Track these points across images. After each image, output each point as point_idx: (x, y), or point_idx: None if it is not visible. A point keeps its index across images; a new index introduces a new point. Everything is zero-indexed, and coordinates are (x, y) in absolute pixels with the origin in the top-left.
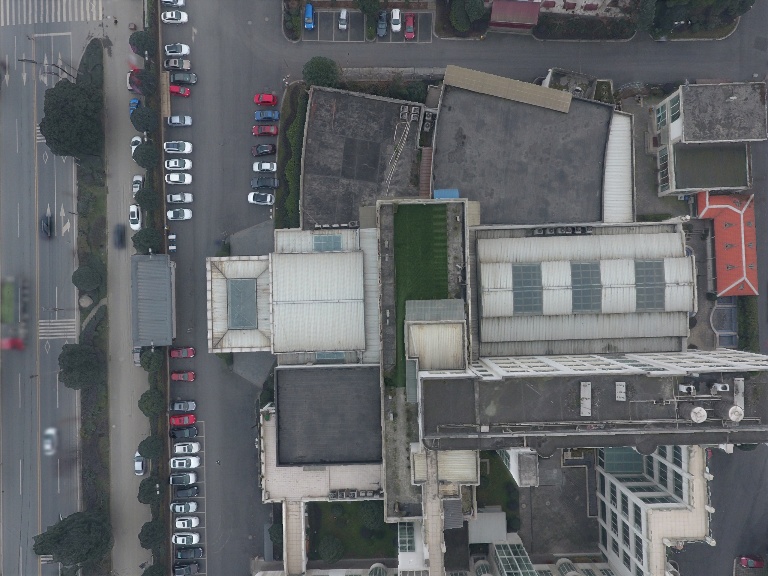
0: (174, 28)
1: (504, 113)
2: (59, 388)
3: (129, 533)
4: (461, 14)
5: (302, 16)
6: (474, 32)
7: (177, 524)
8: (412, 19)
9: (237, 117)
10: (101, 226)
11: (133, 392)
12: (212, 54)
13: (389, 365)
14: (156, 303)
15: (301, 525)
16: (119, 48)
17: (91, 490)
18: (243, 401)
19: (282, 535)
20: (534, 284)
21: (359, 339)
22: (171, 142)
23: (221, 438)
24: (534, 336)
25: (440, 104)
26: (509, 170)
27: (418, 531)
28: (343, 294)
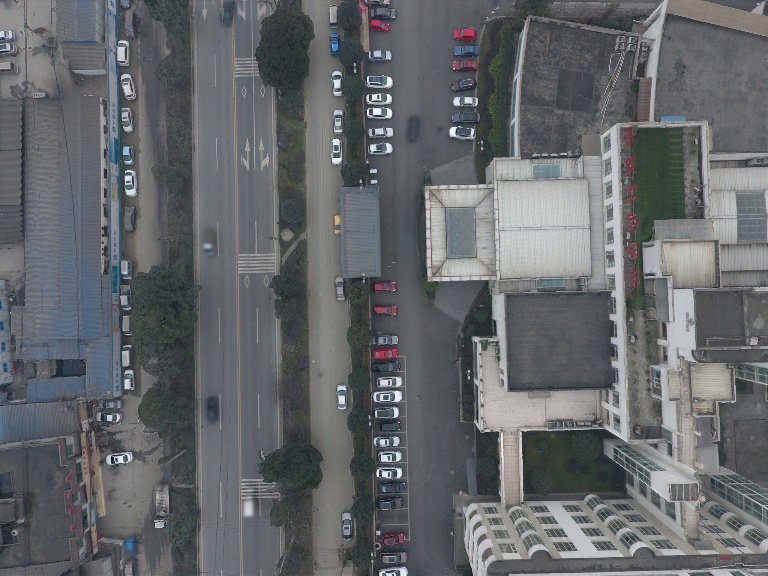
0: None
1: (724, 43)
2: (259, 322)
3: (329, 468)
4: None
5: None
6: None
7: (382, 458)
8: None
9: (436, 53)
10: (301, 160)
11: (333, 327)
12: None
13: (627, 288)
14: (364, 235)
15: (518, 455)
16: None
17: (294, 424)
18: (444, 336)
19: (495, 466)
20: (758, 212)
21: (585, 266)
22: (374, 76)
23: (422, 373)
24: (752, 266)
25: (662, 33)
26: (729, 99)
27: (650, 456)
28: (569, 221)
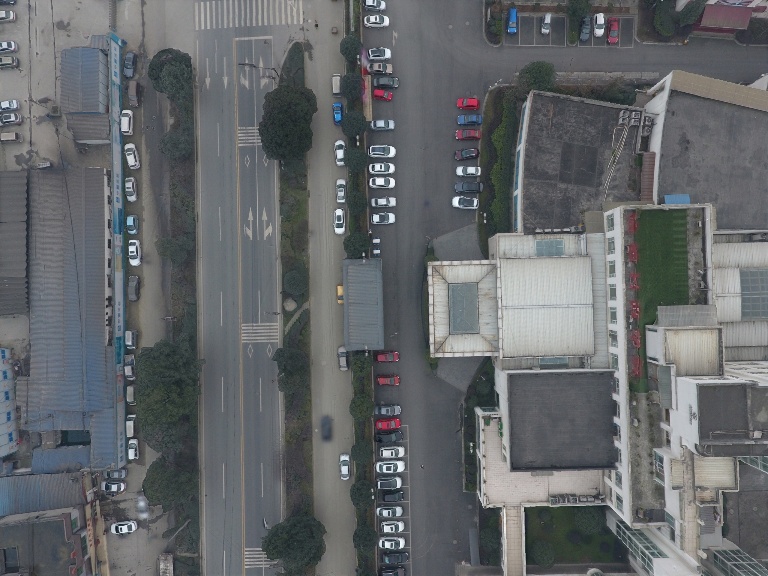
0: (375, 32)
1: (728, 118)
2: (262, 392)
3: (332, 537)
4: (667, 19)
5: (503, 20)
6: (676, 37)
7: (385, 529)
8: (617, 24)
9: (438, 121)
10: (304, 230)
11: (336, 396)
12: (413, 58)
13: (630, 370)
14: (367, 307)
15: (521, 530)
16: (320, 52)
17: (297, 494)
18: (447, 405)
19: (498, 540)
20: (762, 289)
21: (588, 344)
22: (377, 146)
23: (425, 442)
24: (756, 341)
25: (666, 109)
26: (733, 175)
27: (653, 537)
28: (572, 299)
